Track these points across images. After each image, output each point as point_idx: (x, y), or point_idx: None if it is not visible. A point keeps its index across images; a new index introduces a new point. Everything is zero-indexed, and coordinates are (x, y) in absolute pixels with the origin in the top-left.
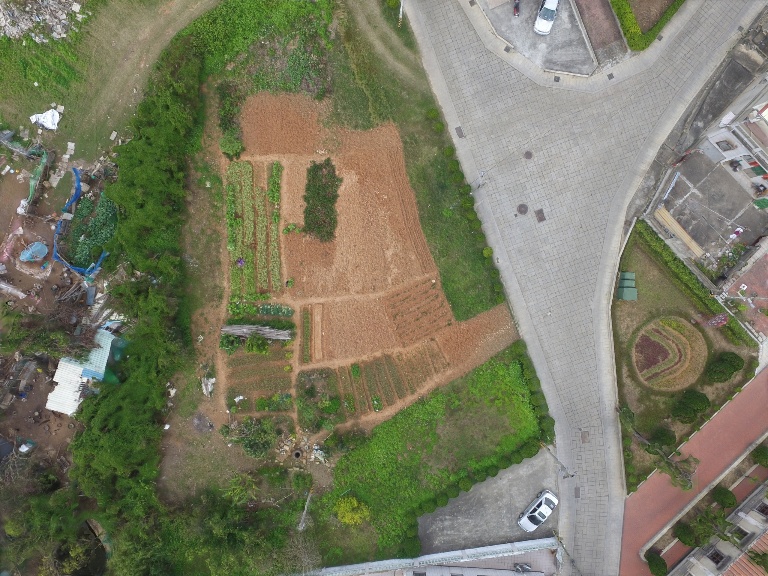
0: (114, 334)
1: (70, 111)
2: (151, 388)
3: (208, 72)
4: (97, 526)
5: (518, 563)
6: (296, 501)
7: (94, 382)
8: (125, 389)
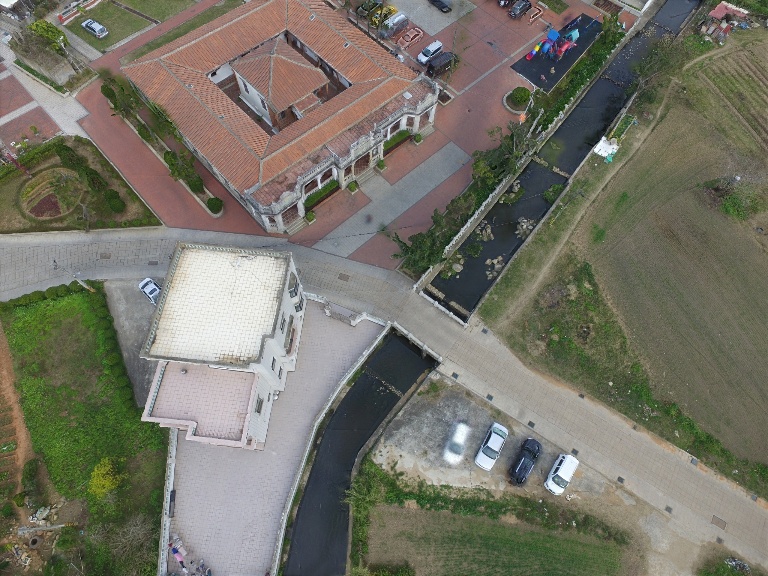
0: None
1: None
2: None
3: None
4: None
5: None
6: (87, 545)
7: None
8: None
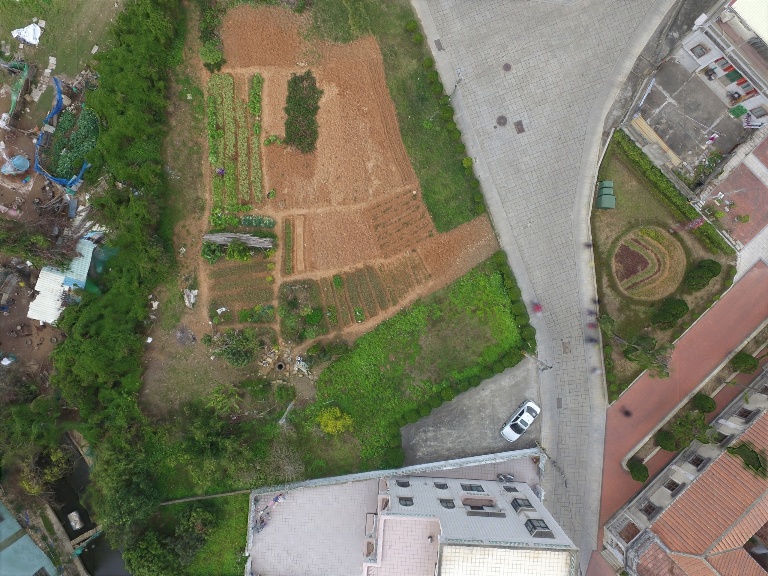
0: (96, 244)
1: (51, 26)
2: (133, 299)
3: None
4: (80, 441)
5: (501, 473)
6: (279, 413)
7: (75, 288)
8: (107, 298)
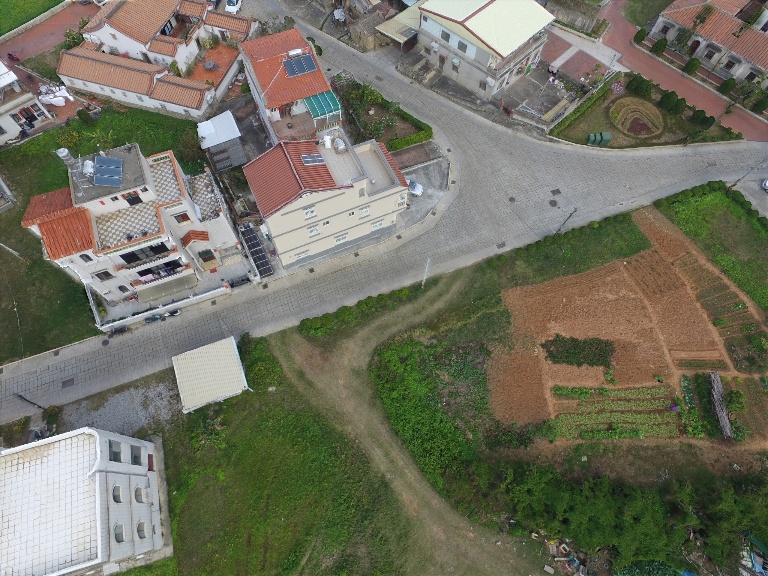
0: None
1: None
2: None
3: (477, 458)
4: None
5: None
6: None
7: None
8: None
